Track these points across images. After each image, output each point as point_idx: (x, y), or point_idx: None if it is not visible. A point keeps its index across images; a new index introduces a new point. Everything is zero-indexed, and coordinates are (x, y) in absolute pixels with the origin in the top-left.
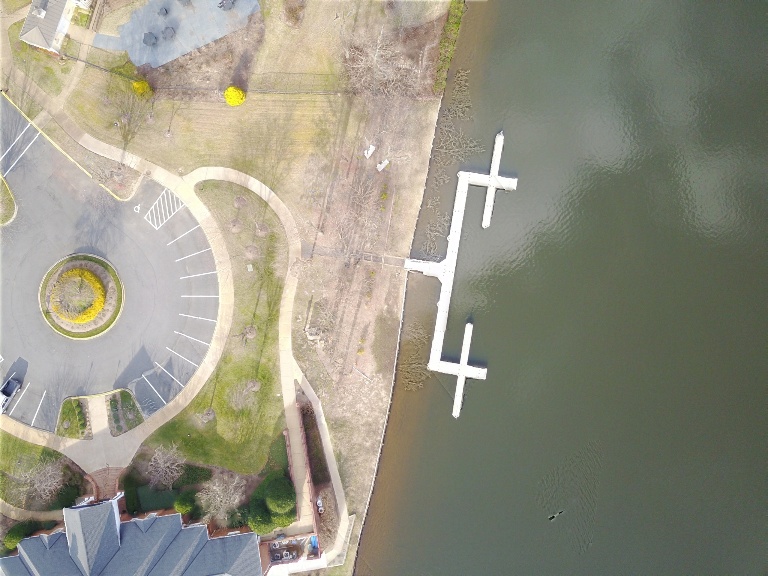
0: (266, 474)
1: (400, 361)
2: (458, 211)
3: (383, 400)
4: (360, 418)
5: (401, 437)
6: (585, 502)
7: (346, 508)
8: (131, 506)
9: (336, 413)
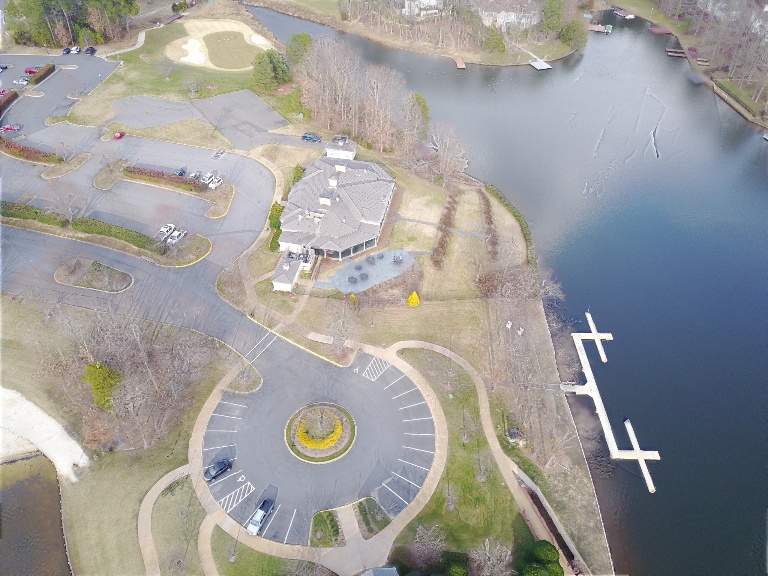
0: (517, 551)
1: (586, 456)
2: (582, 354)
3: (587, 485)
4: (575, 502)
5: (615, 518)
6: None
7: None
8: None
9: (555, 497)
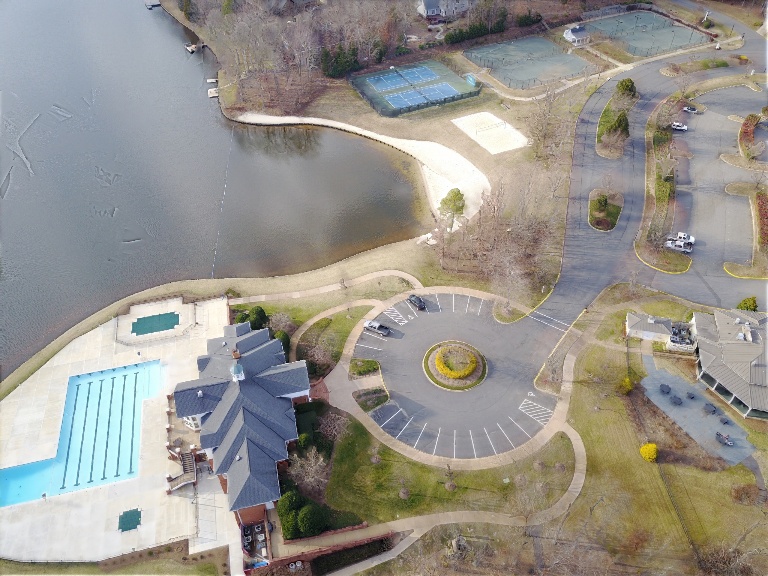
0: None
1: None
2: None
3: None
4: None
5: None
6: None
7: None
8: (301, 407)
9: (384, 575)
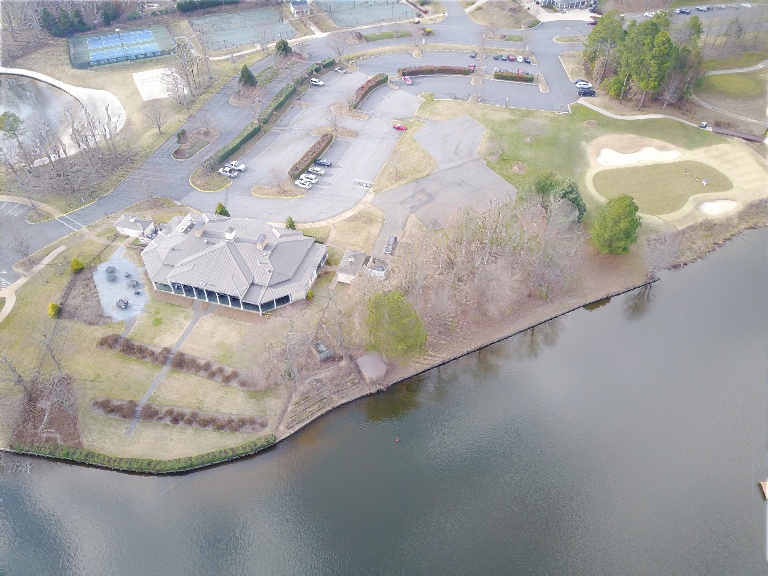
0: None
1: None
2: None
3: None
4: None
5: None
6: None
7: None
8: None
9: None
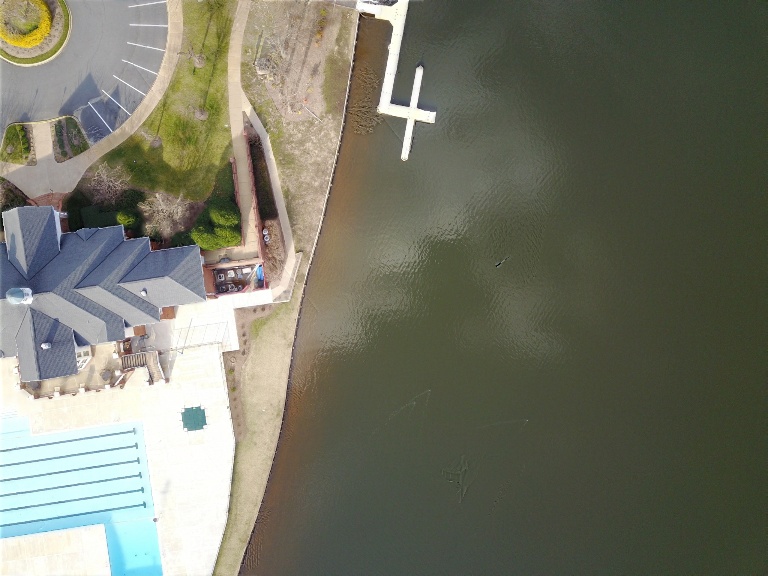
0: None
1: (350, 104)
2: None
3: (332, 140)
4: (309, 157)
5: (350, 180)
6: (531, 245)
7: (293, 245)
8: (74, 225)
9: (284, 149)
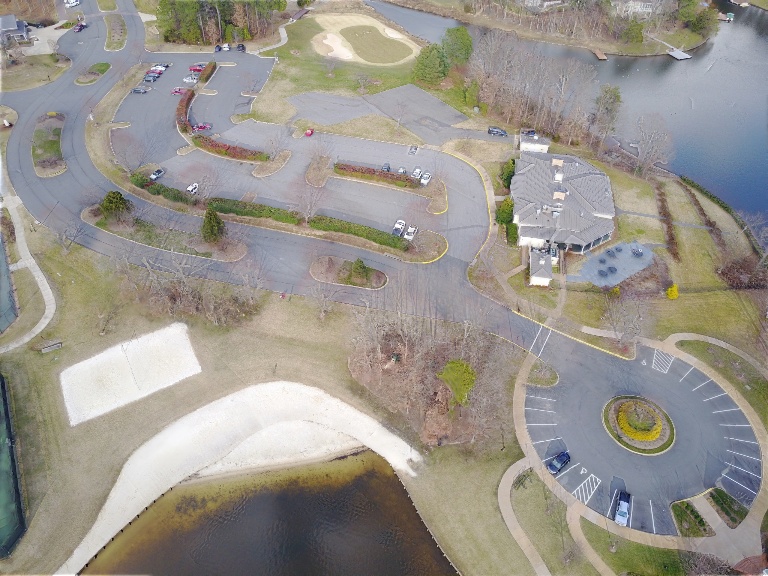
0: None
1: None
2: None
3: None
4: None
5: None
6: None
7: None
8: None
9: None
